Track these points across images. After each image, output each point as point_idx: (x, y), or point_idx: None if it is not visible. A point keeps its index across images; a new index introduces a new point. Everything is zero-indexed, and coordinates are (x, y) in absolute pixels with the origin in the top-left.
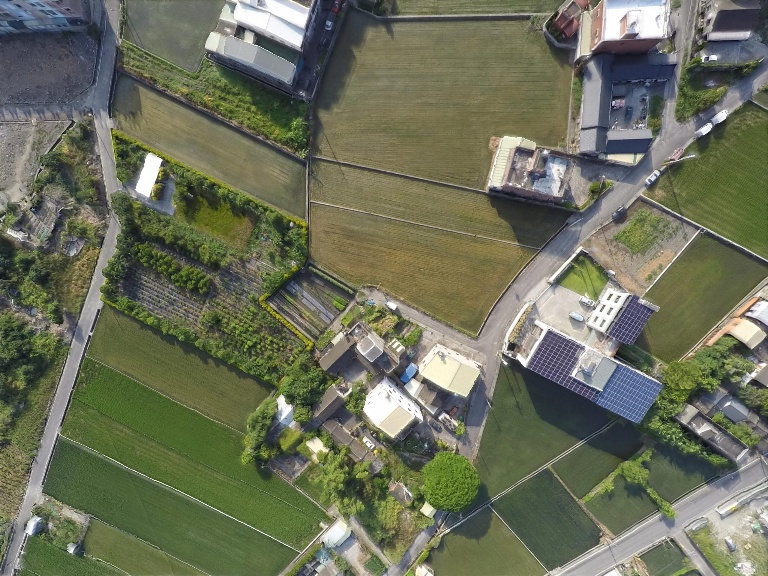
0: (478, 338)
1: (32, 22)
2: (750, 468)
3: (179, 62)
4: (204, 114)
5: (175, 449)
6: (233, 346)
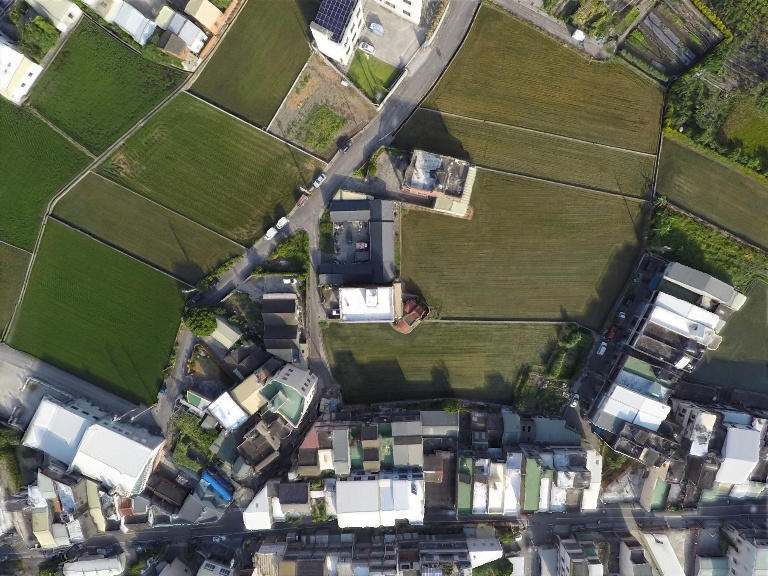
0: (480, 0)
1: None
2: None
3: None
4: (753, 244)
5: None
6: None
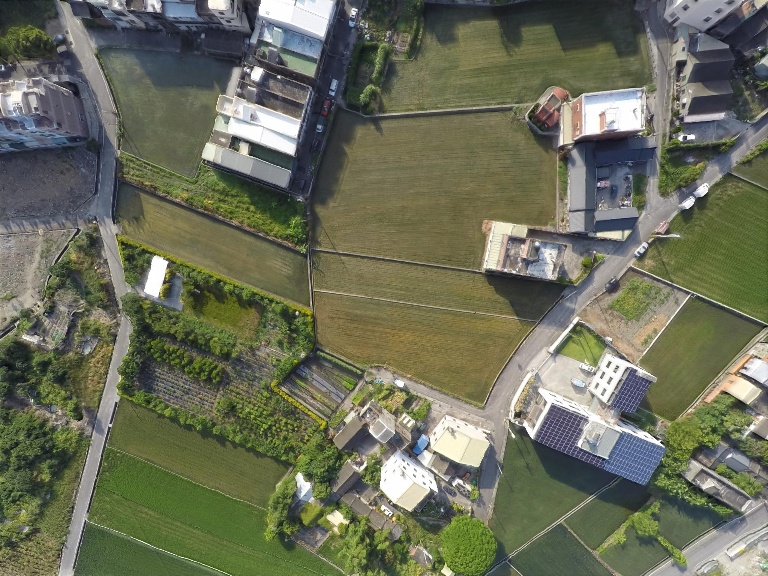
0: (485, 407)
1: (33, 143)
2: (755, 512)
3: (177, 169)
4: (205, 215)
5: (200, 528)
6: (249, 429)
